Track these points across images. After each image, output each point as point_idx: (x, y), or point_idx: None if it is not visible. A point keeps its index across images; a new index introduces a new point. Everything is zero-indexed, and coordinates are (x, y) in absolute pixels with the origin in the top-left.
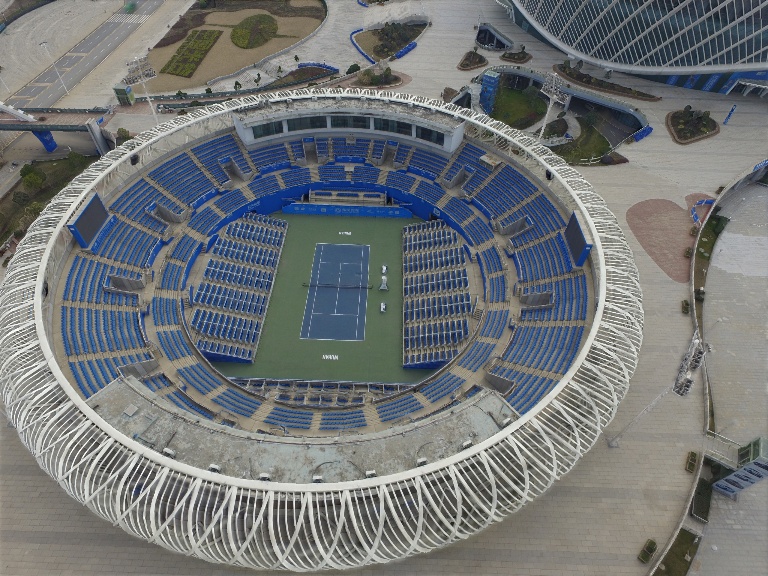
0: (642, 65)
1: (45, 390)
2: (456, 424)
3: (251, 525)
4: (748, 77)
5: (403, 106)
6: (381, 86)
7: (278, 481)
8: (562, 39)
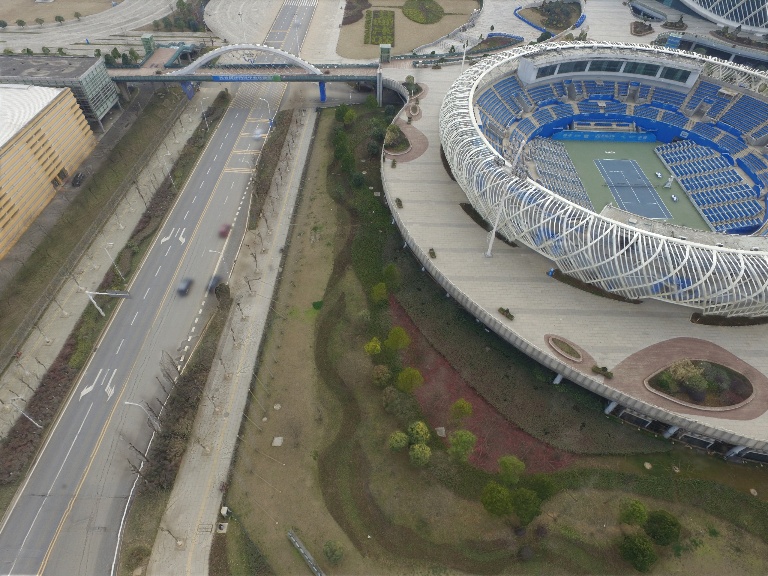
0: None
1: (569, 210)
2: None
3: (767, 270)
4: None
5: (648, 53)
6: None
7: None
8: (713, 10)
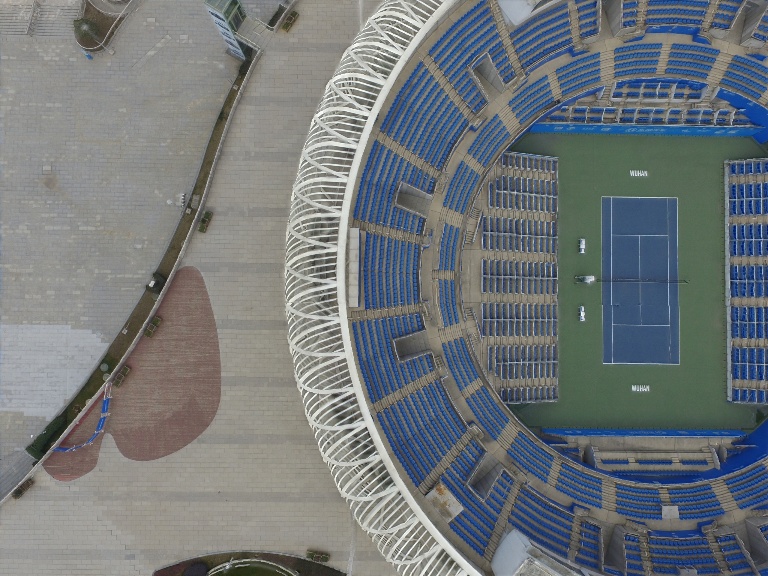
0: None
1: None
2: None
3: None
4: None
5: None
6: None
7: None
8: None
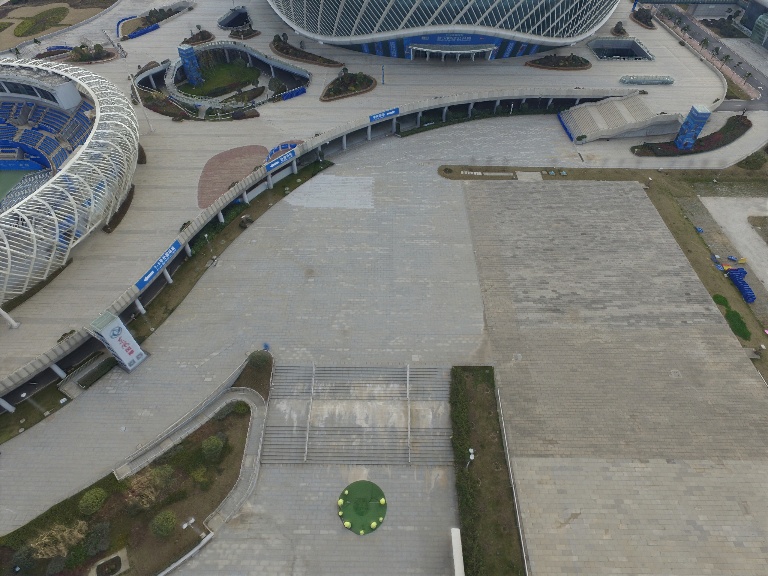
0: (338, 36)
1: None
2: None
3: None
4: (418, 42)
5: (31, 71)
6: (88, 61)
7: None
8: (287, 16)
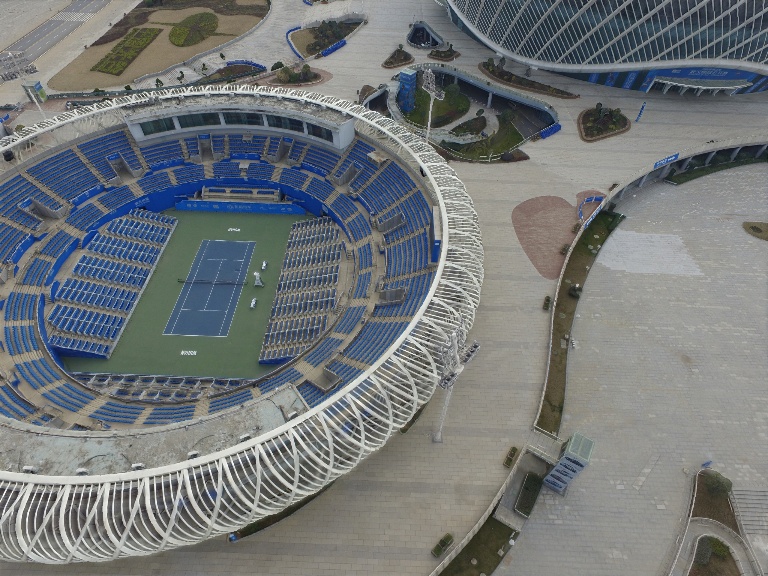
0: (563, 63)
1: None
2: (243, 418)
3: None
4: (664, 75)
5: (296, 103)
6: (299, 84)
7: (44, 474)
8: (490, 37)
